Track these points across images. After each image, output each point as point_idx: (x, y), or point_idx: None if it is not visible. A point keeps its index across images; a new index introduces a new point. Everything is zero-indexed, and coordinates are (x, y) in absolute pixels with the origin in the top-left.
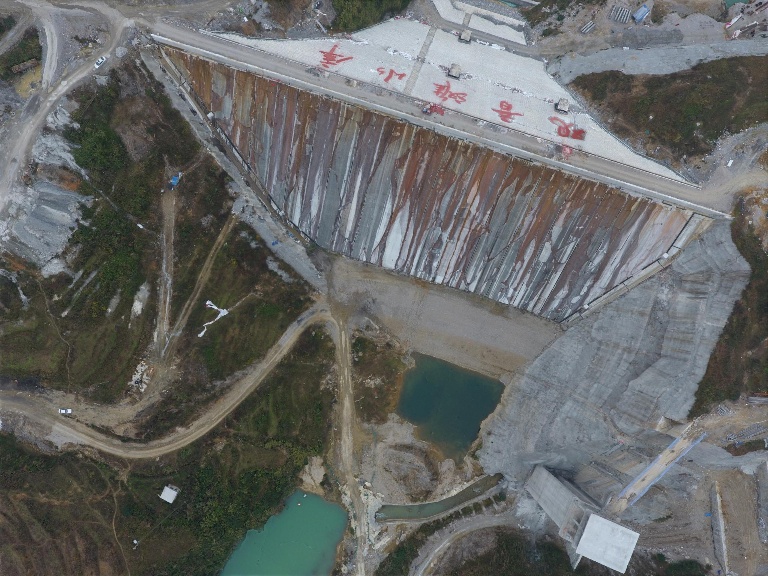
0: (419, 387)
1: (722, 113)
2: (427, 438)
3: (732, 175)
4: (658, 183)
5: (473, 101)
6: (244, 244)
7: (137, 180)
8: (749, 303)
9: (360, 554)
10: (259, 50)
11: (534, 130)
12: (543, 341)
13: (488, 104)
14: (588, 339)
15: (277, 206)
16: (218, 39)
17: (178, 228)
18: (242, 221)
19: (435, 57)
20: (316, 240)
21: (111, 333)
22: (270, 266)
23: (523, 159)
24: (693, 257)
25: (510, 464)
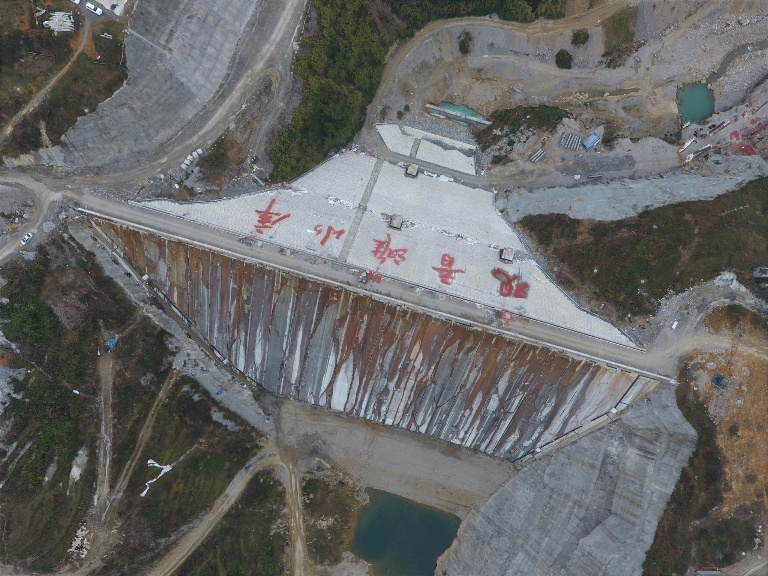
0: (374, 523)
1: (667, 269)
2: (383, 575)
3: (677, 338)
4: (601, 347)
5: (413, 259)
6: (186, 399)
7: (71, 348)
8: (696, 471)
9: None
10: (190, 220)
11: (474, 291)
12: (497, 480)
13: (429, 261)
14: (540, 485)
15: (221, 355)
16: (148, 210)
17: (116, 390)
18: (184, 375)
19: (378, 203)
20: (263, 384)
21: (49, 502)
22: (214, 417)
23: (463, 324)
24: (641, 415)
25: None
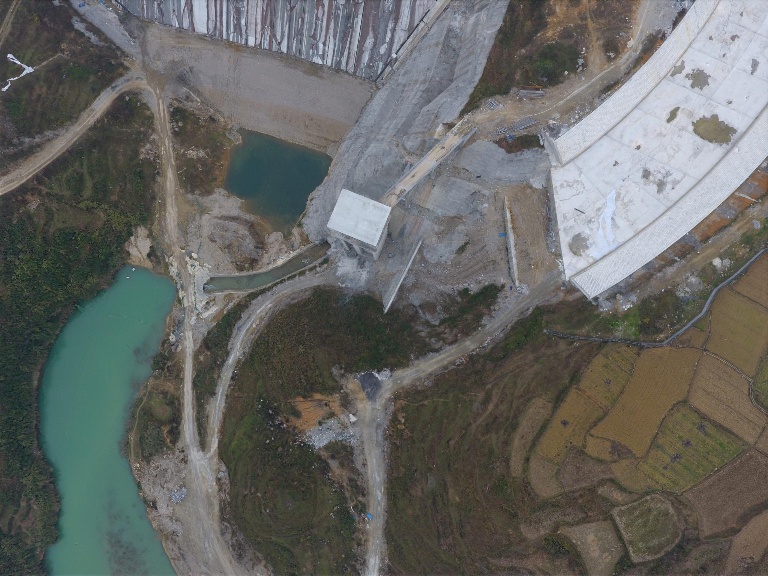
0: (247, 164)
1: None
2: (255, 212)
3: None
4: None
5: None
6: None
7: None
8: None
9: (188, 323)
10: None
11: None
12: (360, 101)
13: None
14: (394, 85)
15: None
16: None
17: None
18: None
19: None
20: (127, 7)
21: None
22: (76, 26)
23: None
24: None
25: None
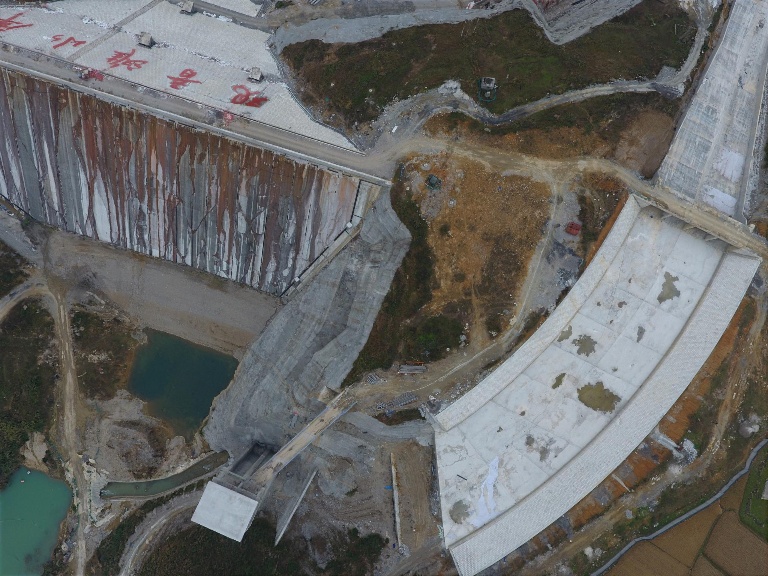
0: (152, 363)
1: (396, 79)
2: (158, 415)
3: (395, 141)
4: (321, 149)
5: (150, 68)
6: None
7: None
8: (407, 270)
9: (81, 531)
10: None
11: (203, 97)
12: (264, 315)
13: (166, 71)
14: (294, 312)
15: None
16: None
17: None
18: None
19: (135, 26)
20: (30, 213)
21: None
22: None
23: (186, 125)
24: (370, 226)
25: (225, 439)
